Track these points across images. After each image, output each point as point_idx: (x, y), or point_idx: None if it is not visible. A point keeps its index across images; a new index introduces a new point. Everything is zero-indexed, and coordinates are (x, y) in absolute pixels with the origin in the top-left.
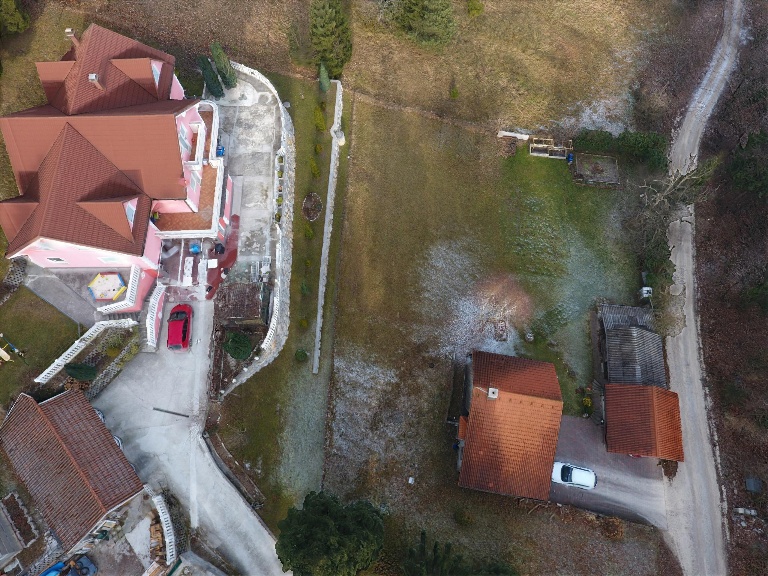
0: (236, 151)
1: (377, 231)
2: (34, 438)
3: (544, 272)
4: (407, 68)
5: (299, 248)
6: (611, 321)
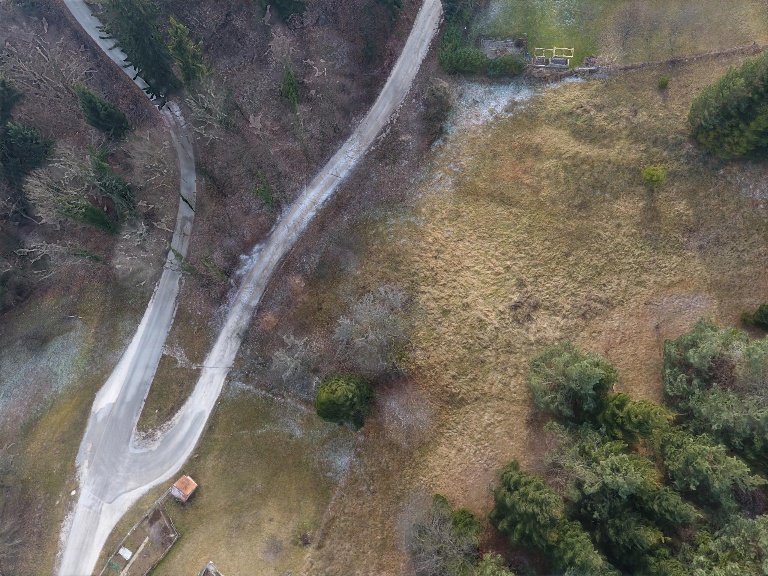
0: None
1: None
2: None
3: None
4: None
5: None
6: None
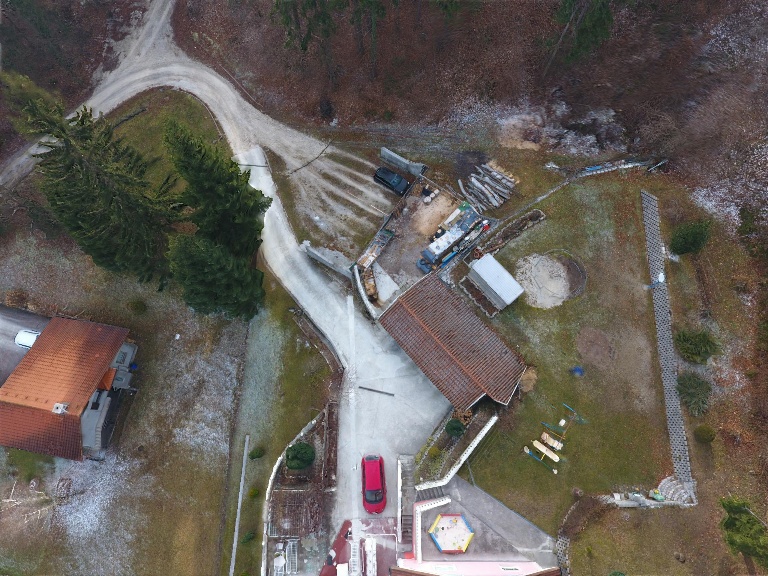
0: None
1: None
2: (484, 362)
3: None
4: None
5: None
6: None
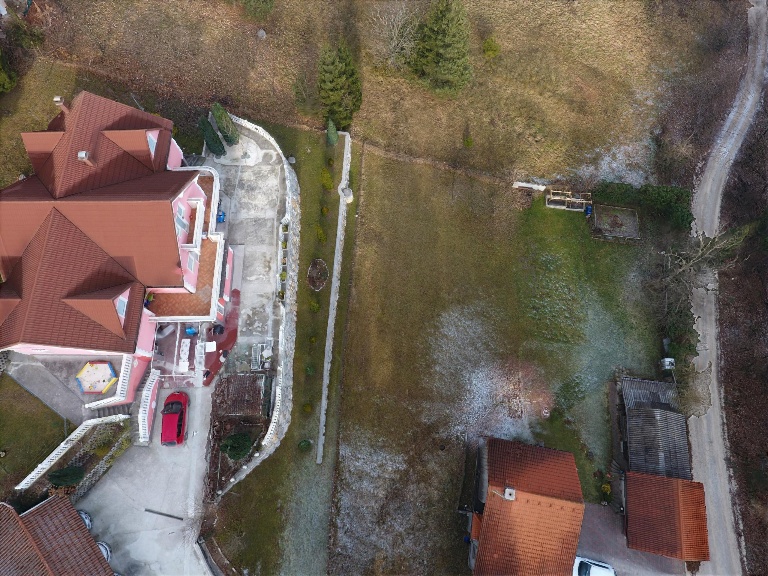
0: (237, 216)
1: (386, 298)
2: (14, 554)
3: (561, 338)
4: (419, 115)
5: (303, 321)
6: (632, 398)
